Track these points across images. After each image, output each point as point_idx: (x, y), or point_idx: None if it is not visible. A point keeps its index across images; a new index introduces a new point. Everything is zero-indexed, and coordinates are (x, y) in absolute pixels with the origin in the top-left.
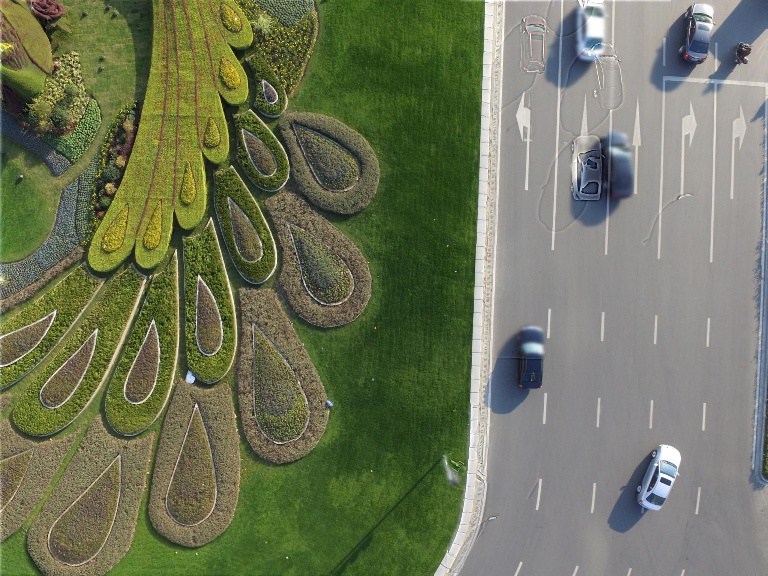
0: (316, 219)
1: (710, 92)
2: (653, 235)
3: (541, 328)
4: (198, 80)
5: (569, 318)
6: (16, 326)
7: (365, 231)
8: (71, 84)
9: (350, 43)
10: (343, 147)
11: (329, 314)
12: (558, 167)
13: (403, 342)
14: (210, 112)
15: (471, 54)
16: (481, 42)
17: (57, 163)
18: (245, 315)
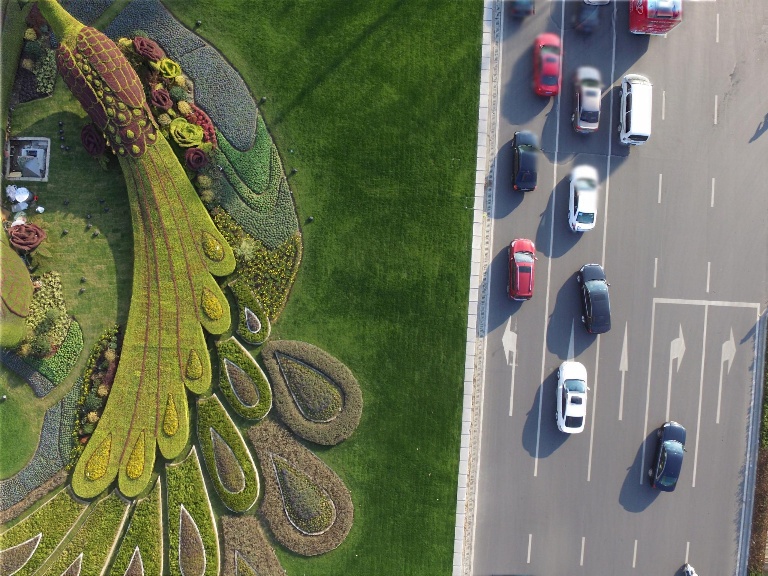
0: (298, 450)
1: (700, 315)
2: (636, 463)
3: (521, 553)
4: (180, 311)
5: (550, 543)
6: (3, 546)
7: (347, 461)
8: (52, 306)
9: (334, 267)
10: (326, 376)
11: (311, 544)
12: (543, 393)
13: (384, 569)
14: (192, 344)
15: (458, 277)
16: (468, 264)
17: (40, 385)
18: (228, 543)
